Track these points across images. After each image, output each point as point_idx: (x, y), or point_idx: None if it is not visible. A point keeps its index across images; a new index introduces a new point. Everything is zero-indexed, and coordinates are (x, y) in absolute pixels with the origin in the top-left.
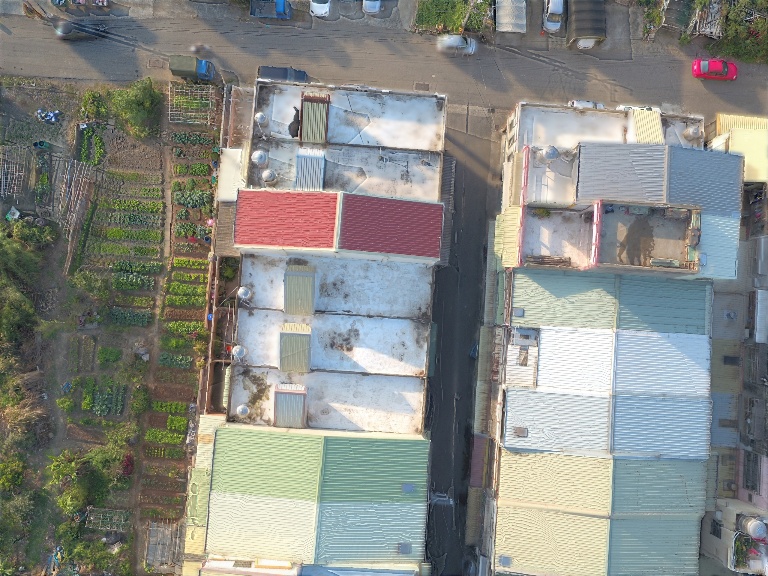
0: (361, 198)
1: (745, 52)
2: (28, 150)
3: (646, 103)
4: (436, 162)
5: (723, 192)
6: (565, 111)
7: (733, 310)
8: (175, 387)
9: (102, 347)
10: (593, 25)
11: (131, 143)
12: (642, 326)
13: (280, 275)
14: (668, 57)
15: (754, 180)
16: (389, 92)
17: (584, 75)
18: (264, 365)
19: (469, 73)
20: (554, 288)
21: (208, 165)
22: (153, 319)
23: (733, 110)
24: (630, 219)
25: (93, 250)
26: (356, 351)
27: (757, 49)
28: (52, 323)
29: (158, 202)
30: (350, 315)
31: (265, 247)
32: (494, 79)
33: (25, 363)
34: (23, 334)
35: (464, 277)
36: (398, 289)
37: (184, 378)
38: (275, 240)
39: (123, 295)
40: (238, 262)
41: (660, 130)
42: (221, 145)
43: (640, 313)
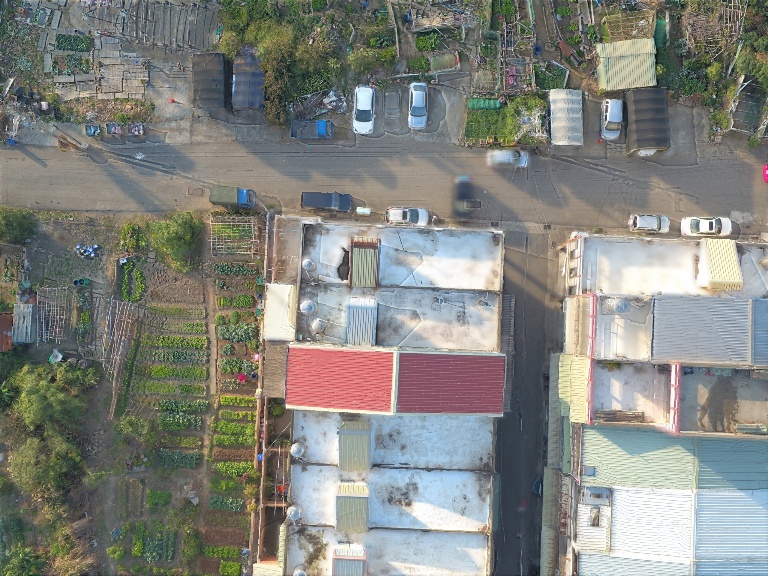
0: (419, 357)
1: None
2: (68, 291)
3: (714, 211)
4: (494, 301)
5: None
6: (631, 241)
7: None
8: (226, 531)
9: (150, 491)
10: (656, 134)
11: (173, 276)
12: (723, 484)
13: (333, 427)
14: (737, 160)
15: None
16: (443, 230)
17: (646, 184)
18: (320, 524)
19: (523, 187)
20: (627, 445)
21: (252, 297)
22: (201, 460)
23: None
24: (711, 380)
25: (138, 390)
26: (415, 506)
27: None
28: (100, 474)
29: (202, 338)
30: (408, 469)
31: (319, 410)
32: (550, 192)
33: (73, 511)
34: (70, 481)
35: (523, 406)
36: (457, 439)
37: (235, 521)
38: (329, 402)
39: (170, 436)
40: None
41: (736, 262)
42: (265, 276)
43: (721, 470)
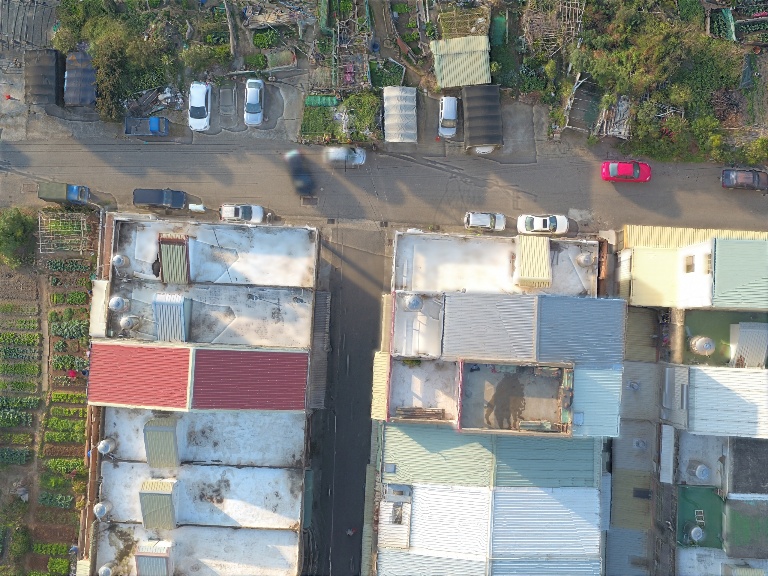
0: (216, 353)
1: (659, 151)
2: None
3: (552, 209)
4: (309, 298)
5: (601, 343)
6: (448, 238)
7: (642, 438)
8: (55, 528)
9: None
10: (488, 132)
11: (6, 273)
12: (522, 481)
13: None
14: (576, 158)
15: (658, 304)
16: (256, 226)
17: (484, 181)
18: (129, 521)
19: (360, 184)
20: (427, 442)
21: (85, 294)
22: (32, 457)
23: (647, 213)
24: (498, 377)
25: None
26: (227, 503)
27: (672, 147)
28: None
29: (34, 334)
30: (219, 466)
31: (118, 406)
32: (387, 190)
33: None
34: None
35: (357, 403)
36: (270, 436)
37: (64, 518)
38: (128, 398)
39: (1, 433)
40: None
41: (548, 259)
42: (98, 273)
43: (520, 468)
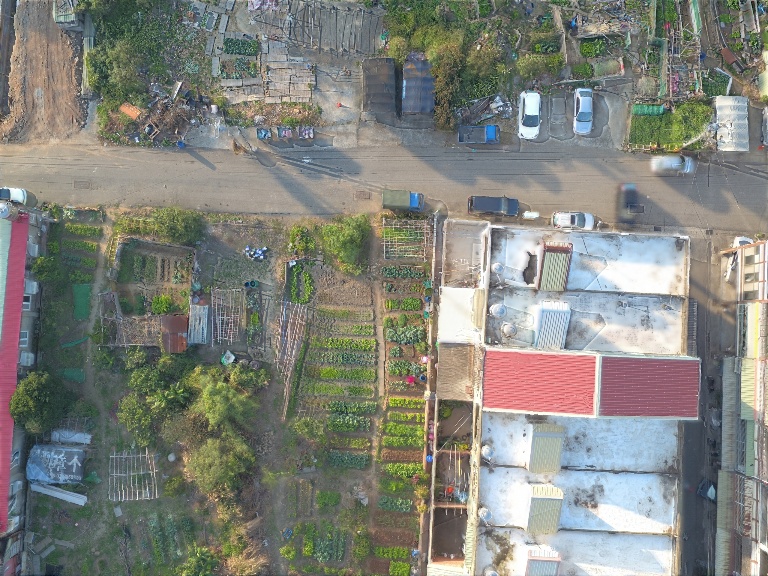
0: (619, 360)
1: None
2: (242, 293)
3: None
4: (677, 305)
5: None
6: None
7: None
8: (395, 531)
9: (320, 491)
10: None
11: (341, 279)
12: None
13: (519, 429)
14: None
15: None
16: None
17: None
18: (508, 525)
19: (685, 192)
20: None
21: (420, 300)
22: (370, 461)
23: None
24: None
25: (307, 391)
26: (601, 508)
27: None
28: (278, 475)
29: (371, 340)
30: (595, 471)
31: (518, 412)
32: (712, 198)
33: (246, 511)
34: (243, 482)
35: None
36: (642, 441)
37: (404, 522)
38: (528, 404)
39: (339, 437)
40: (456, 401)
41: None
42: (433, 279)
43: None
